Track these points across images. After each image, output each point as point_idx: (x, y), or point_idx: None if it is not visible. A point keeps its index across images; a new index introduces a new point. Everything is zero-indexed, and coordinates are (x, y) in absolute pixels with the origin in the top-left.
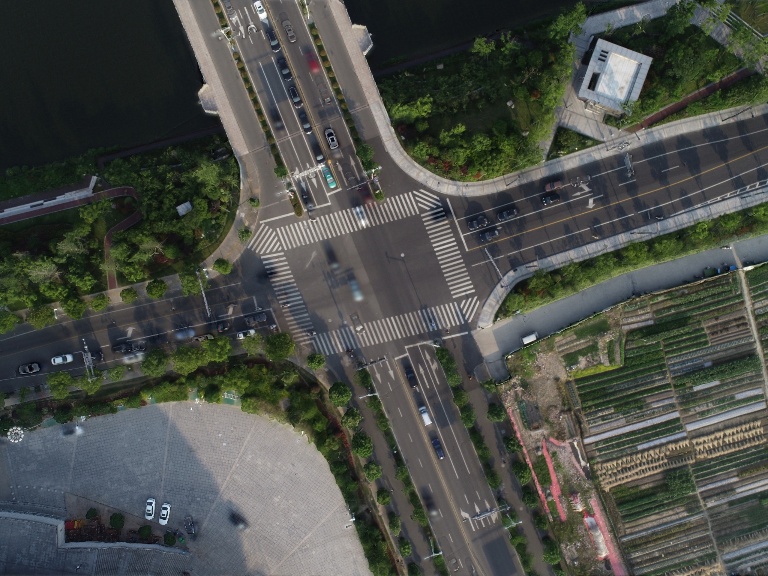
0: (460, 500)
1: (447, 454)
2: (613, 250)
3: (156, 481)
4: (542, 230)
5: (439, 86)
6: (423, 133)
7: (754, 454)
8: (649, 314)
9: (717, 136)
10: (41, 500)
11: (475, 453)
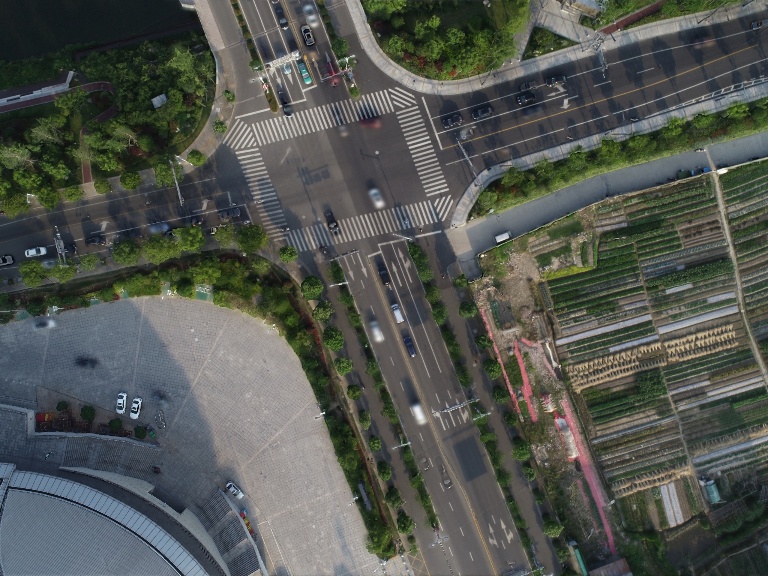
0: (431, 399)
1: (419, 353)
2: (587, 151)
3: (128, 376)
4: (517, 130)
5: None
6: (399, 30)
7: (726, 358)
8: (623, 216)
9: (692, 39)
10: (13, 393)
11: (447, 352)
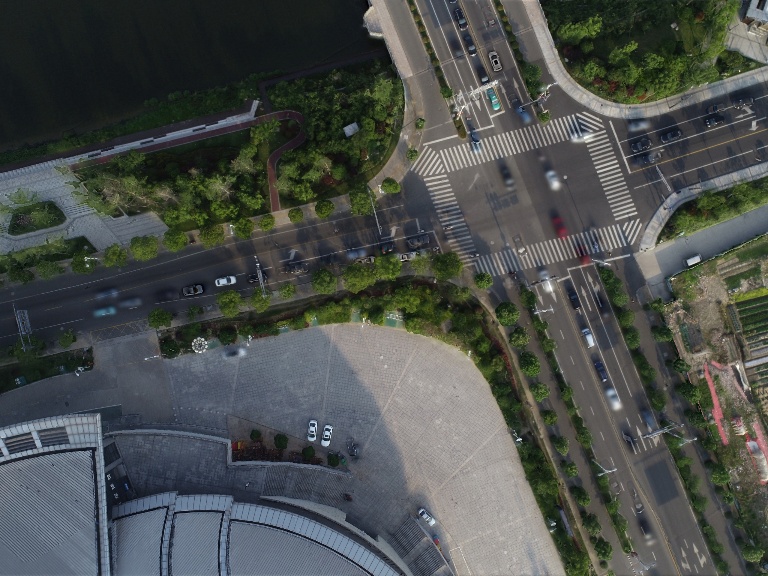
0: (622, 423)
1: (609, 377)
2: None
3: (318, 403)
4: (705, 152)
5: (603, 8)
6: (588, 54)
7: None
8: None
9: None
10: (203, 422)
11: (637, 376)
